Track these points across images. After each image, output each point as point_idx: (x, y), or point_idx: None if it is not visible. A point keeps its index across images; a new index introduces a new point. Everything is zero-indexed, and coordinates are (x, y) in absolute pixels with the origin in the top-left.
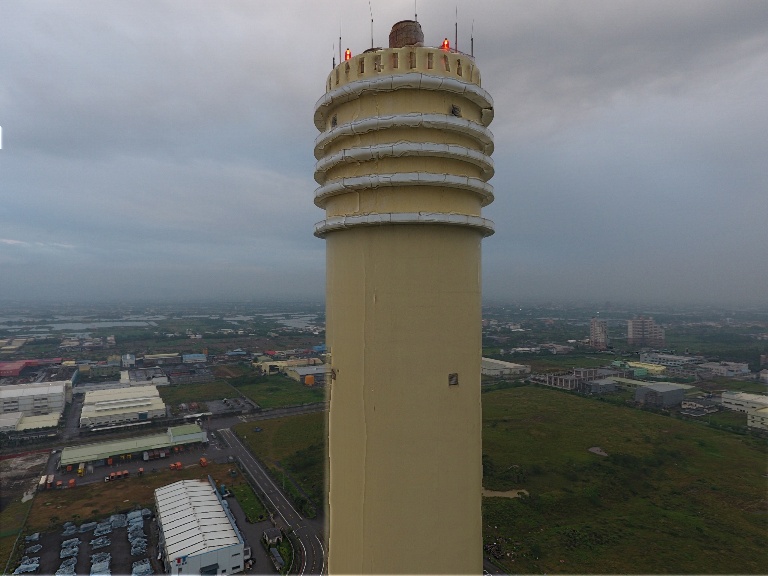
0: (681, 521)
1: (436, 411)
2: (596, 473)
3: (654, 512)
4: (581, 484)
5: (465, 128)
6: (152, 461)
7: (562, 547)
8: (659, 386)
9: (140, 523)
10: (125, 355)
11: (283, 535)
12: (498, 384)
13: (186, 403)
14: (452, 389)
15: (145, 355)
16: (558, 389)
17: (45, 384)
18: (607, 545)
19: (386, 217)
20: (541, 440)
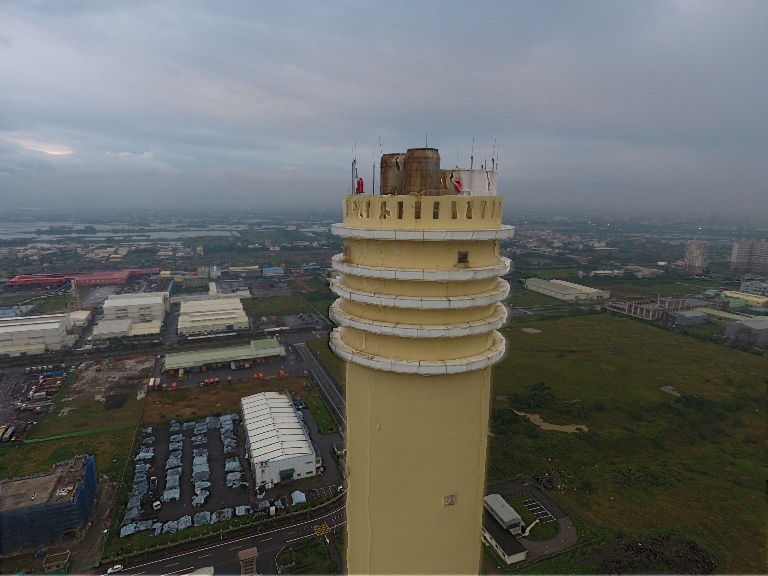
0: (750, 471)
1: (431, 526)
2: (664, 414)
3: (721, 459)
4: (645, 424)
5: (469, 279)
6: (238, 370)
7: (615, 485)
8: (756, 322)
9: (230, 426)
10: (212, 267)
11: None
12: (571, 310)
13: (266, 316)
14: (447, 508)
15: (229, 267)
16: (637, 319)
17: (147, 295)
18: (663, 487)
19: (387, 365)
20: (609, 375)
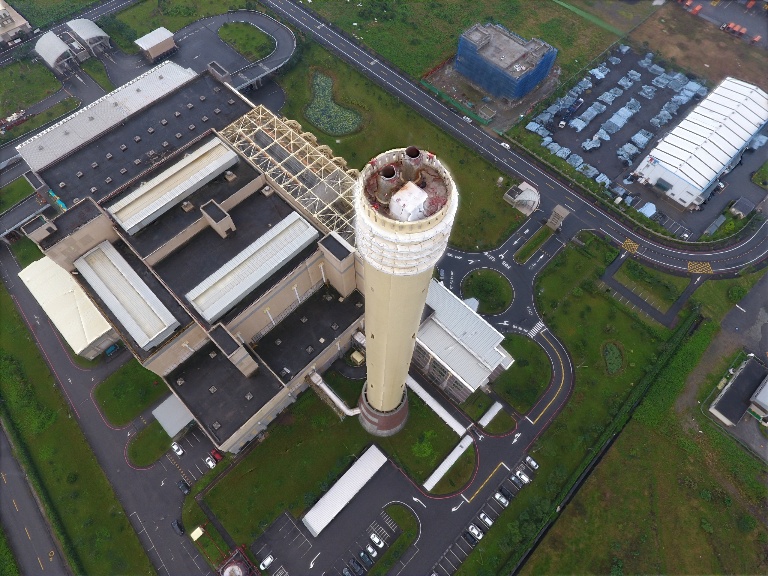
0: None
1: None
2: None
3: None
4: None
5: None
6: None
7: None
8: None
9: (686, 99)
10: None
11: (750, 216)
12: None
13: None
14: None
15: None
16: None
17: None
18: None
19: None
20: None
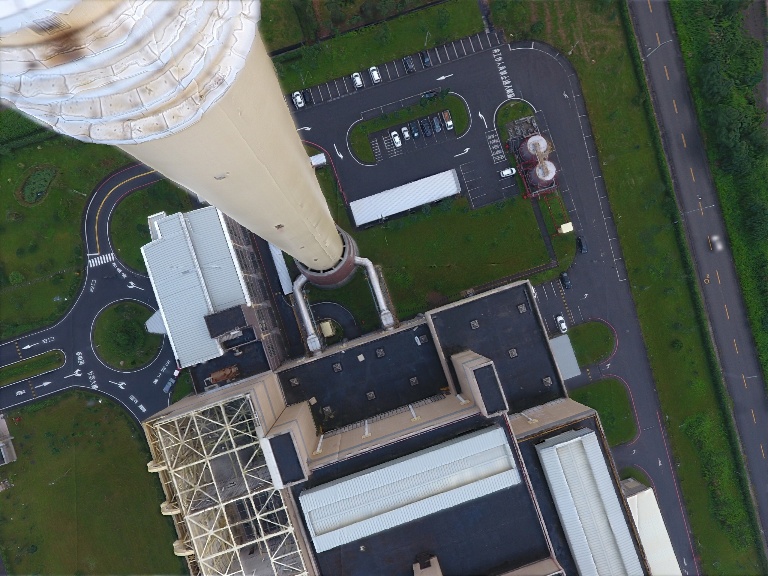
0: None
1: None
2: None
3: None
4: None
5: None
6: None
7: None
8: None
9: None
10: None
11: None
12: None
13: None
14: None
15: None
16: None
17: None
18: None
19: (237, 61)
20: None
